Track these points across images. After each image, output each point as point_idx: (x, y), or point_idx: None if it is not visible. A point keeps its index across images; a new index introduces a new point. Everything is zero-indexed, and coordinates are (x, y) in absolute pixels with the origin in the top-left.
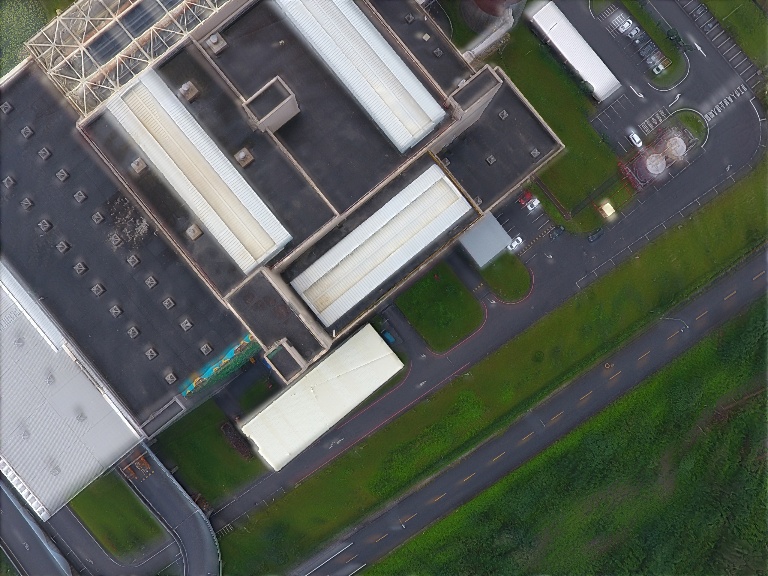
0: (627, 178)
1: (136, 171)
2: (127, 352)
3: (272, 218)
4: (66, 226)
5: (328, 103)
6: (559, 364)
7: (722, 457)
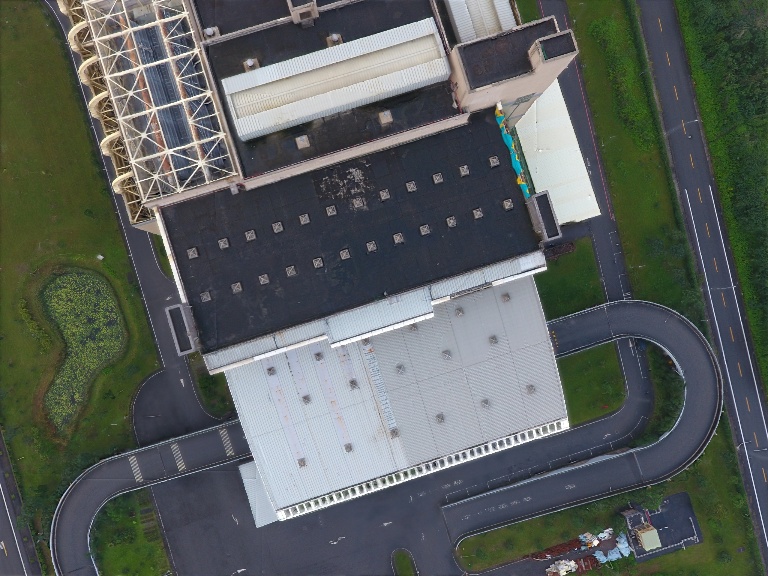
0: None
1: (307, 146)
2: (467, 236)
3: (408, 27)
4: (326, 244)
5: None
6: None
7: None
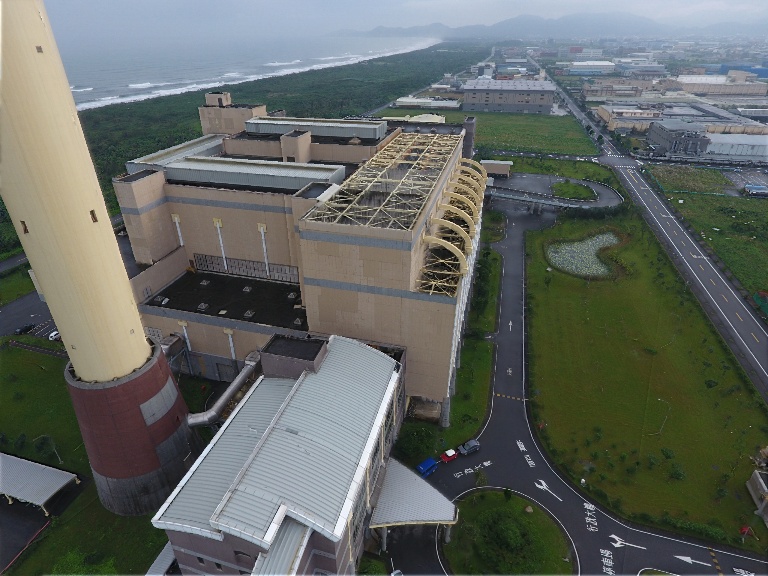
0: None
1: None
2: None
3: None
4: None
5: None
6: None
7: None
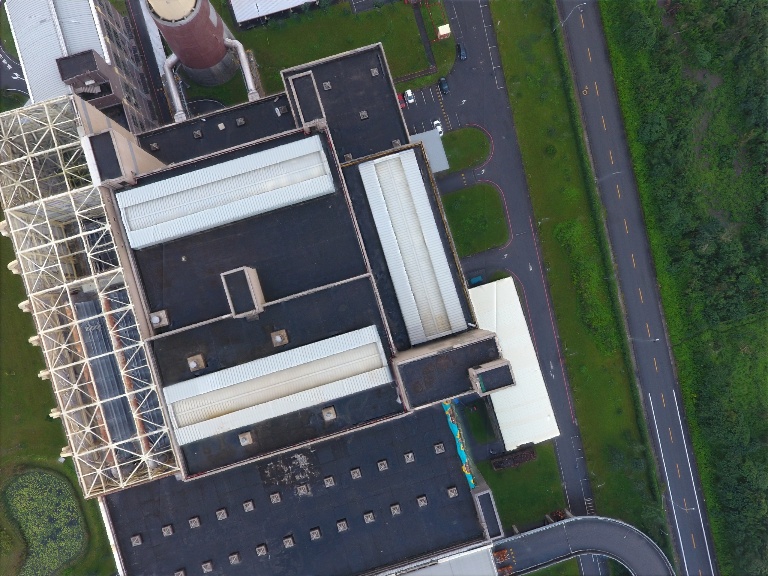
0: (422, 1)
1: (250, 444)
2: (411, 523)
3: (351, 335)
4: (270, 531)
5: (259, 240)
6: (566, 135)
7: (712, 24)
